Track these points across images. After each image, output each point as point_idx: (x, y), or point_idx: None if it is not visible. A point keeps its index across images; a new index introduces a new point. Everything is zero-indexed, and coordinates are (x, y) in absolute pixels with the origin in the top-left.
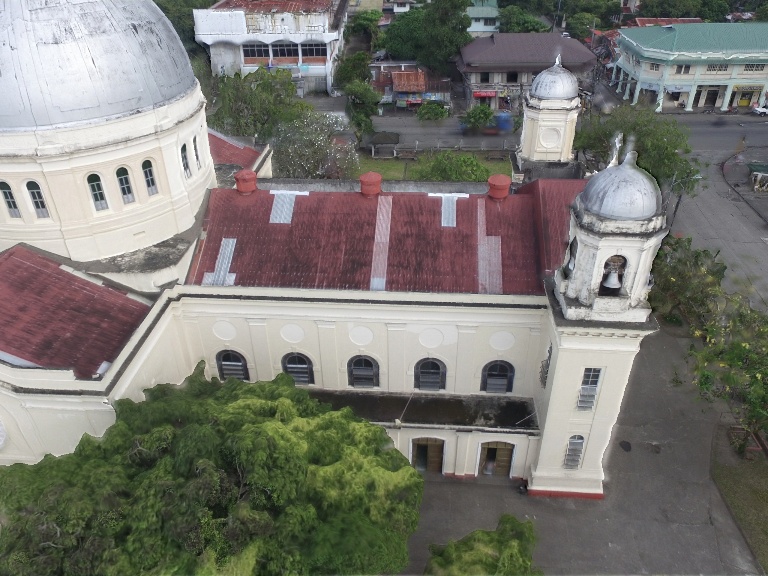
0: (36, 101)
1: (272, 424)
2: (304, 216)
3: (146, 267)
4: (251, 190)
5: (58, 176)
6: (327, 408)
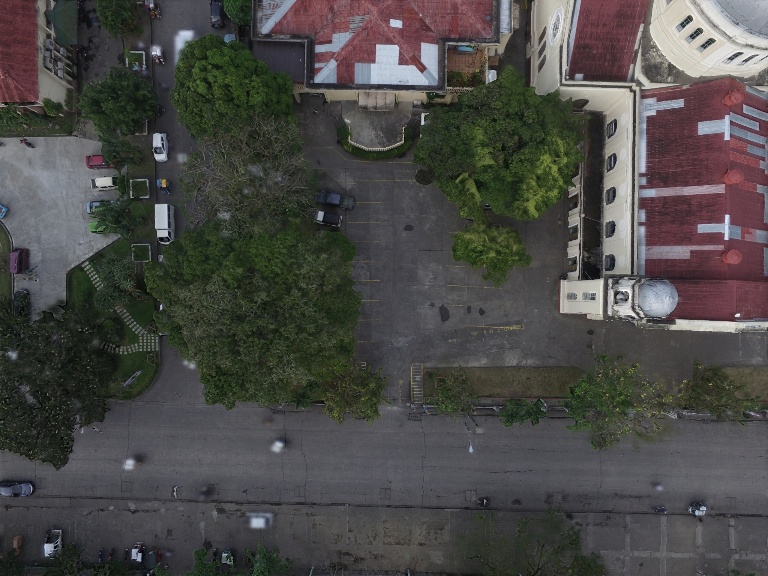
0: None
1: (546, 157)
2: (705, 141)
3: (647, 67)
4: (726, 103)
5: None
6: (567, 179)
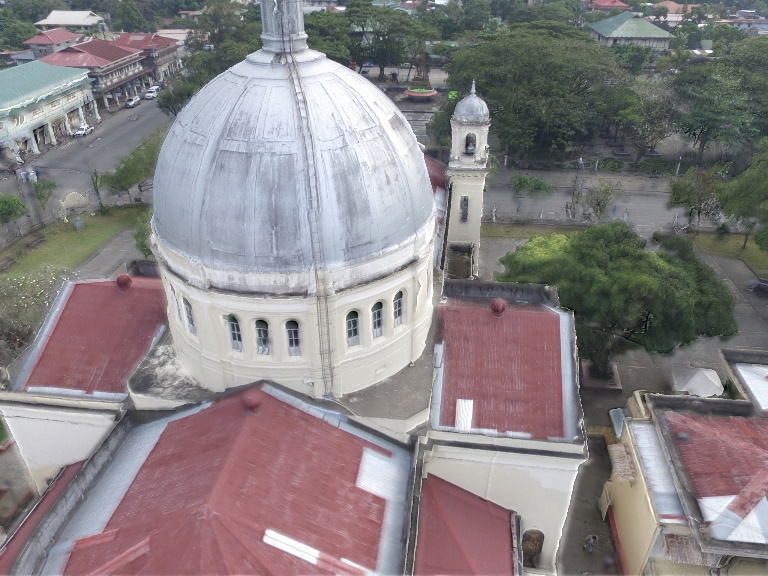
0: None
1: None
2: None
3: (435, 274)
4: None
5: None
6: None
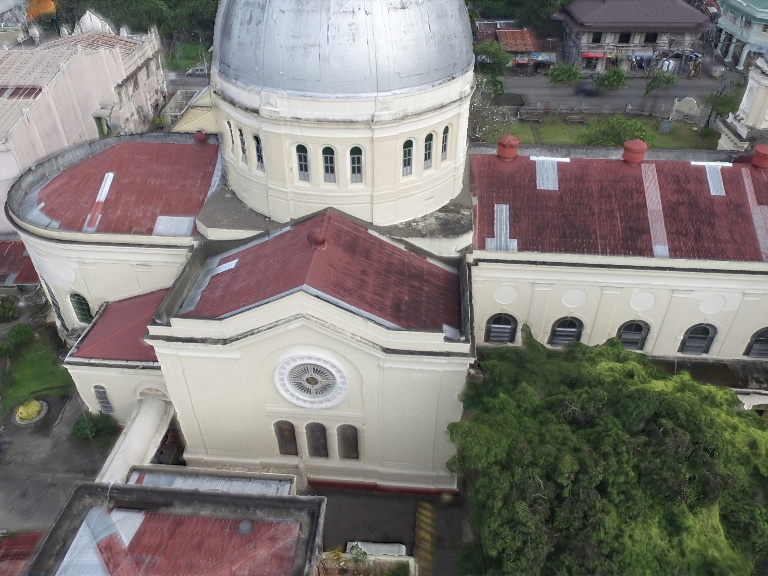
0: (382, 67)
1: (658, 386)
2: (570, 183)
3: (446, 232)
4: (514, 156)
5: (384, 142)
6: None
